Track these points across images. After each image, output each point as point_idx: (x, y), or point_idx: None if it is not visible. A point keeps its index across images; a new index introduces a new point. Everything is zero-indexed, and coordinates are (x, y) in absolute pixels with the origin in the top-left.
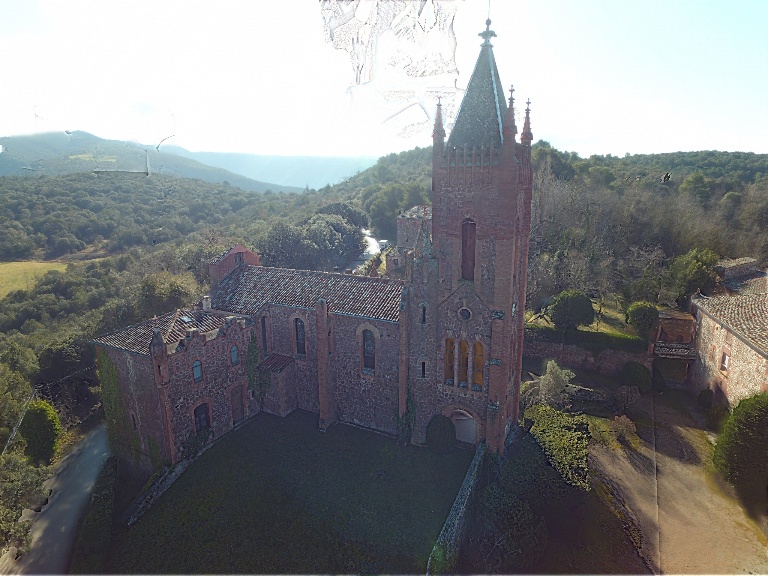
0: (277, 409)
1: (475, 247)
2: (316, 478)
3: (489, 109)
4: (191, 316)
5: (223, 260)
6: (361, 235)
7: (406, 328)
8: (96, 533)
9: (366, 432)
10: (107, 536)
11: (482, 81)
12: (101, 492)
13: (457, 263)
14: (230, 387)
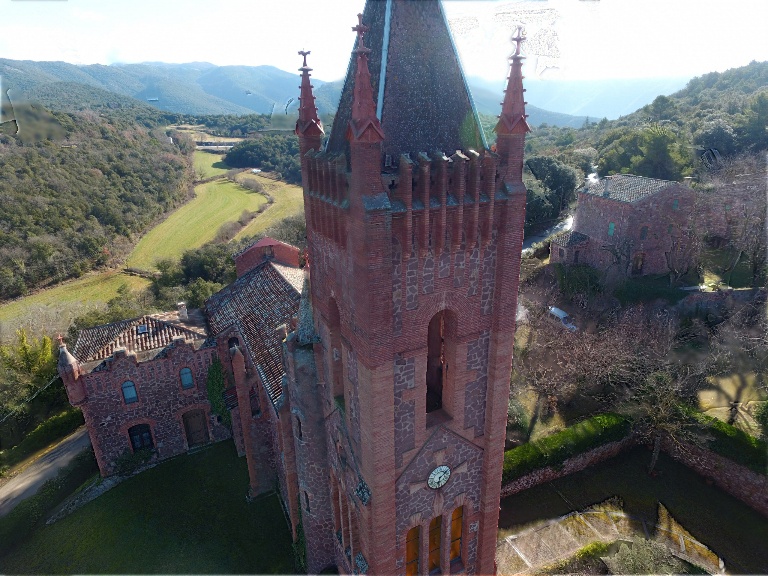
0: (236, 445)
1: (342, 355)
2: (179, 569)
3: (372, 73)
4: (152, 326)
5: (243, 254)
6: (558, 202)
7: (287, 433)
8: (4, 526)
9: (284, 527)
10: (9, 533)
11: (376, 5)
12: (53, 478)
13: (331, 368)
14: (181, 410)
